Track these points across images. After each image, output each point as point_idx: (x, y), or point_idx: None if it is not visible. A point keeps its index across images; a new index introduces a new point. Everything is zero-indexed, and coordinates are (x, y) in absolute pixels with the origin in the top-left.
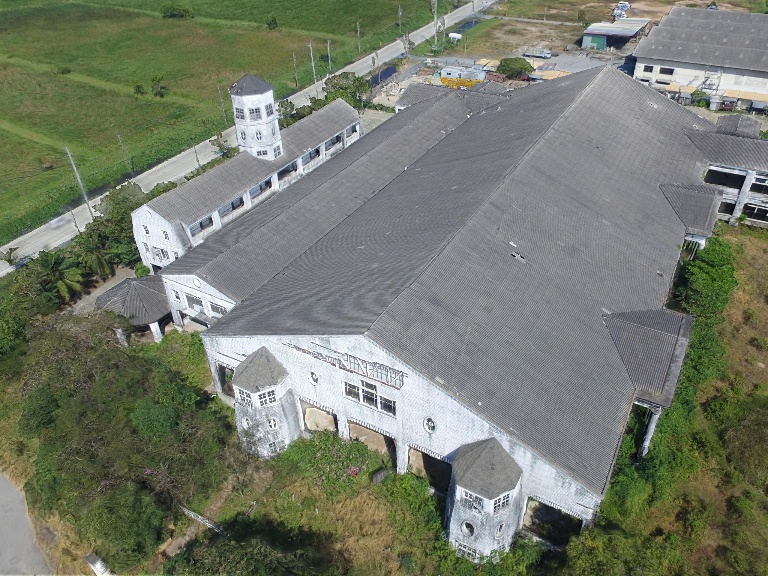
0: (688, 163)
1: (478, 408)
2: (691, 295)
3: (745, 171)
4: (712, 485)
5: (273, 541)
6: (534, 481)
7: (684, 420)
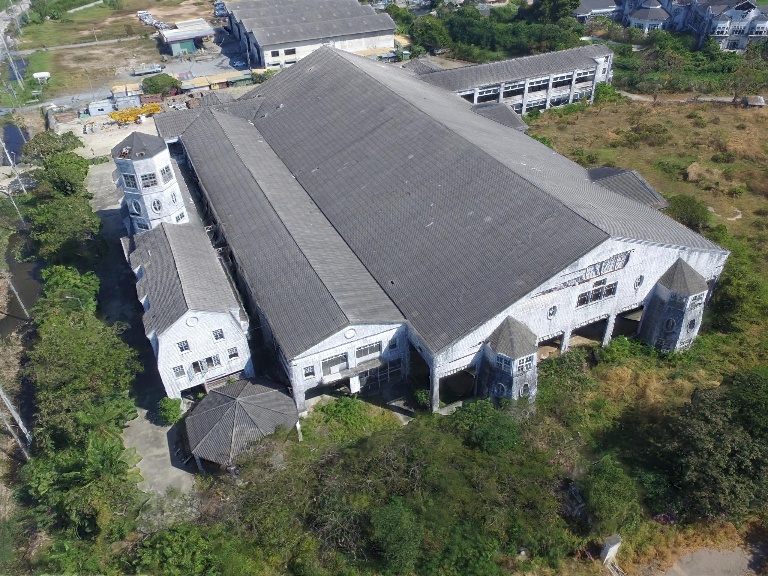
0: (451, 95)
1: (672, 243)
2: None
3: (473, 90)
4: None
5: (620, 439)
6: None
7: None
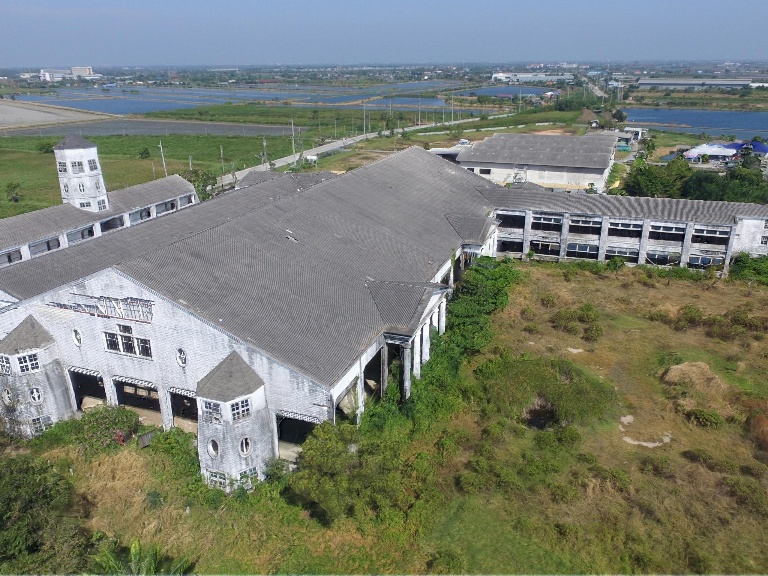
0: (475, 206)
1: (218, 322)
2: (463, 284)
3: (524, 212)
4: (471, 421)
5: None
6: (275, 392)
7: (453, 378)
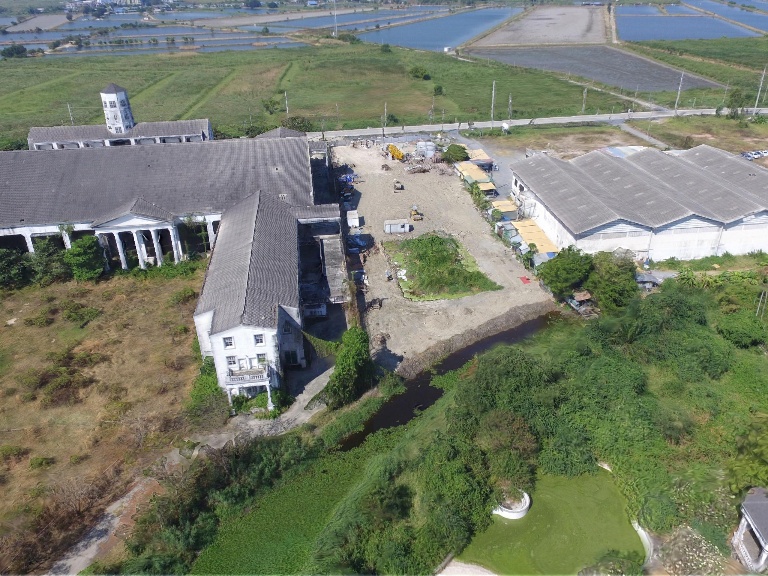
0: (201, 203)
1: None
2: None
3: None
4: None
5: None
6: None
7: None
